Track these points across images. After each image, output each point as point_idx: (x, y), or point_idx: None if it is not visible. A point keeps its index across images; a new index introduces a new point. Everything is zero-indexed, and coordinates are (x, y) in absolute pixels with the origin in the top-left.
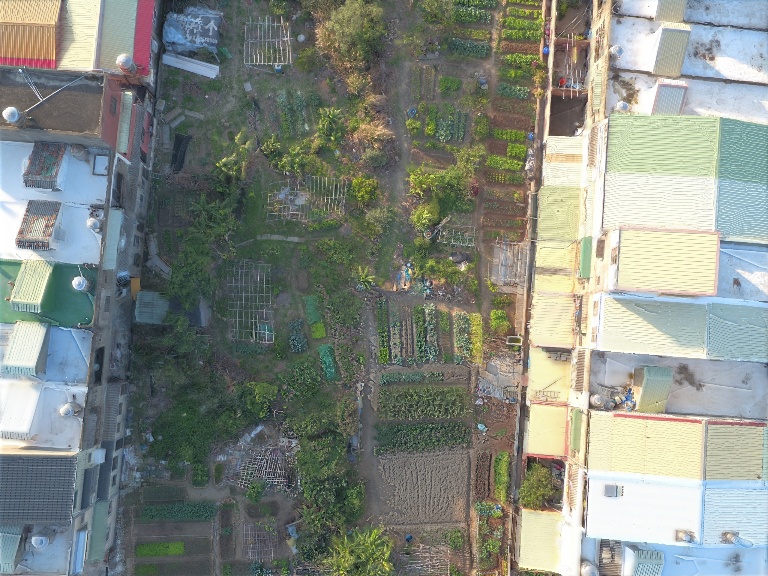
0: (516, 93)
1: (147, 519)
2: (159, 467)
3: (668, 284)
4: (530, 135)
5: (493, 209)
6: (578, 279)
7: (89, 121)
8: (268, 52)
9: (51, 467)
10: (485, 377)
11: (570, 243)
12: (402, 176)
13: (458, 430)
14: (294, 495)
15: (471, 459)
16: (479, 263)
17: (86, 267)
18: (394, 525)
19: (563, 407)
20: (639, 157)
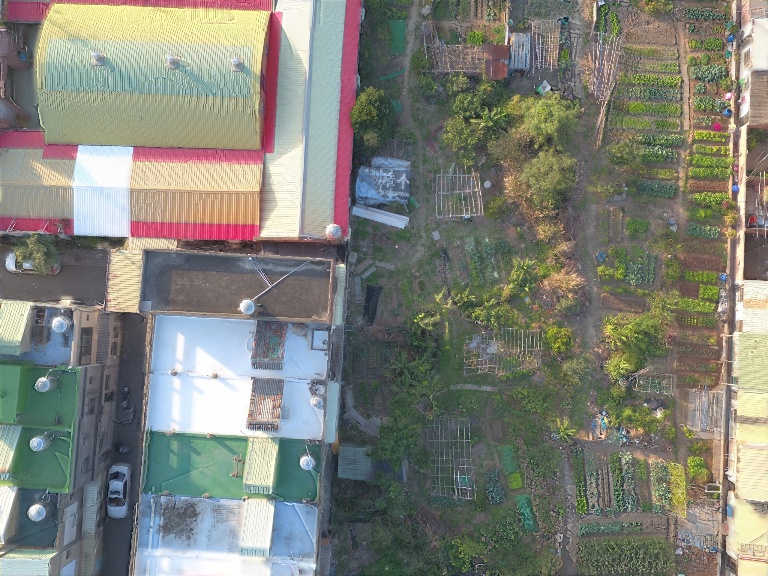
0: (706, 233)
1: None
2: None
3: None
4: (723, 277)
5: (686, 352)
6: None
7: (316, 305)
8: (460, 204)
9: None
10: (684, 525)
11: None
12: (593, 321)
13: None
14: None
15: None
16: (674, 408)
17: (309, 443)
18: None
19: None
20: None
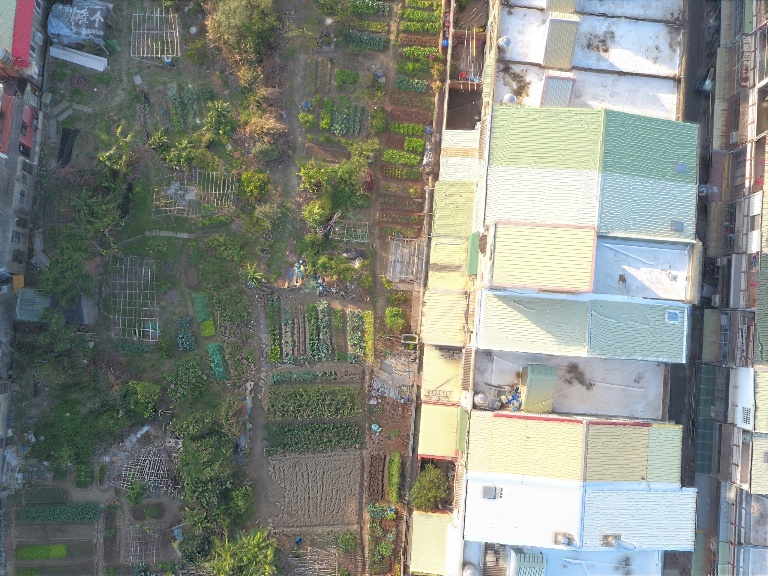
0: (414, 86)
1: (28, 521)
2: (41, 468)
3: (546, 280)
4: (427, 129)
5: (389, 204)
6: (469, 276)
7: None
8: (156, 44)
9: None
10: (380, 376)
11: (466, 239)
12: (296, 171)
13: (350, 430)
14: (181, 497)
15: (364, 460)
16: (375, 260)
17: None
18: (284, 527)
19: (454, 407)
20: (518, 150)
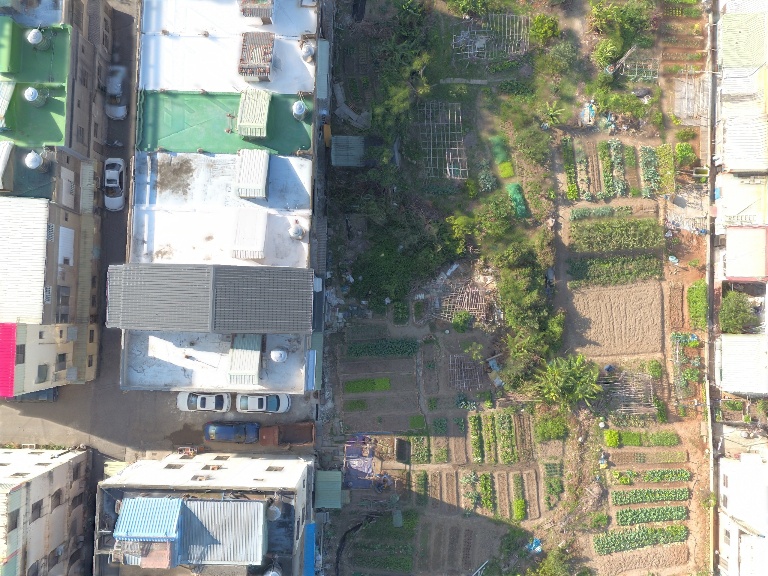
0: None
1: (352, 357)
2: (361, 307)
3: None
4: None
5: (672, 43)
6: None
7: None
8: None
9: (290, 279)
10: (673, 209)
11: (755, 70)
12: (579, 15)
13: (650, 261)
14: (492, 330)
15: (663, 291)
16: (661, 97)
17: (302, 95)
18: (591, 357)
19: (762, 228)
20: None
